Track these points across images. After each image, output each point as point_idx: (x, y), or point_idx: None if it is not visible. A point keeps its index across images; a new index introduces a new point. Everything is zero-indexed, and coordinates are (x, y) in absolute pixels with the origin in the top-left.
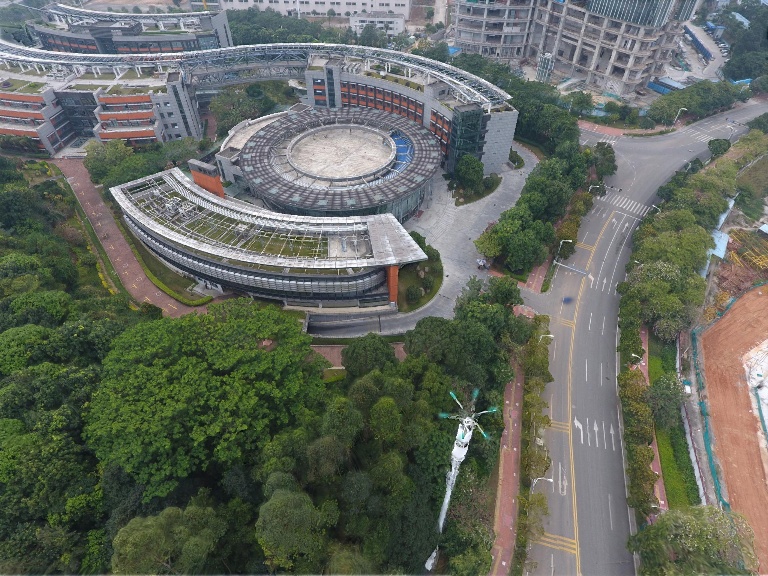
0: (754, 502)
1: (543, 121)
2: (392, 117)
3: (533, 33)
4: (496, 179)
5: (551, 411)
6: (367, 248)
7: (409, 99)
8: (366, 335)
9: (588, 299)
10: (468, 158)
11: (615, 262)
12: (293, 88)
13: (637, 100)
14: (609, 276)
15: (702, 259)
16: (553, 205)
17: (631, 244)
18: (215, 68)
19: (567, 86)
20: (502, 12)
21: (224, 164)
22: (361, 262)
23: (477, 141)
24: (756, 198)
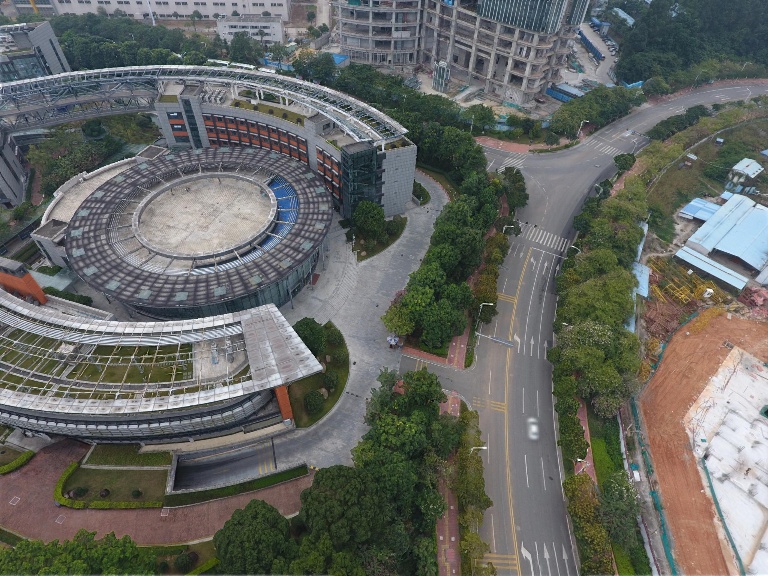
0: None
1: (445, 147)
2: (270, 158)
3: (424, 37)
4: (401, 222)
5: (493, 541)
6: (246, 354)
7: (289, 134)
8: (247, 506)
9: (517, 369)
10: (365, 206)
11: (540, 315)
12: (151, 115)
13: (538, 109)
14: (536, 334)
15: (630, 308)
16: (467, 256)
17: (554, 289)
18: (30, 105)
19: (466, 96)
20: (389, 15)
21: (45, 245)
22: (234, 389)
23: (374, 183)
24: (666, 217)
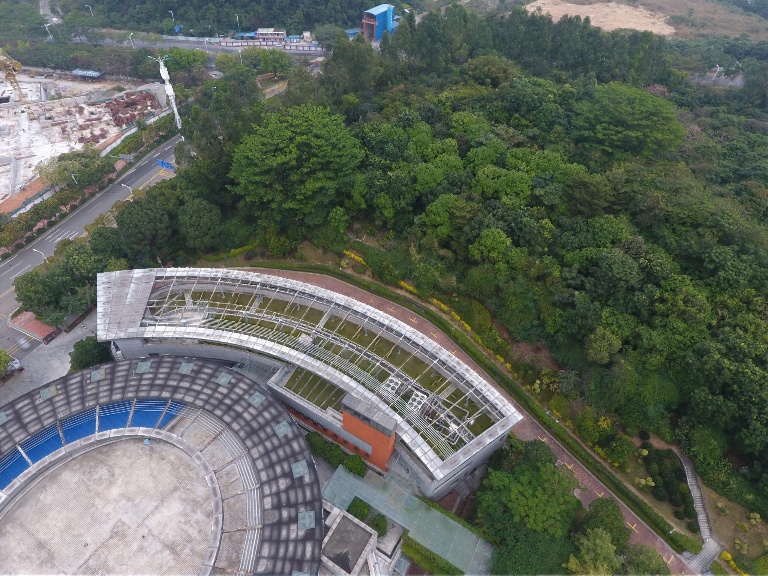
0: (3, 210)
1: None
2: None
3: None
4: None
5: None
6: None
7: None
8: None
9: None
10: None
11: None
12: None
13: None
14: None
15: None
16: None
17: None
18: None
19: None
20: None
21: None
22: (172, 272)
23: None
24: None
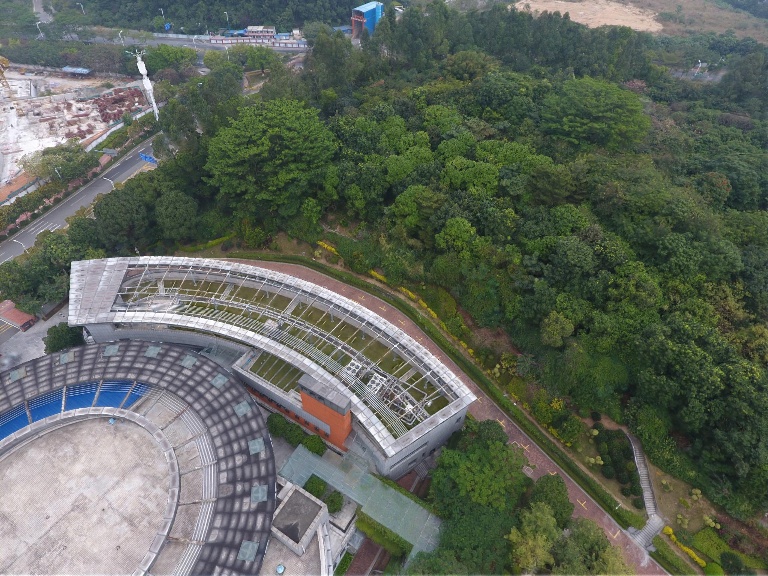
0: None
1: None
2: None
3: None
4: None
5: None
6: None
7: None
8: (172, 222)
9: None
10: None
11: None
12: None
13: None
14: None
15: None
16: None
17: None
18: None
19: None
20: None
21: None
22: (145, 260)
23: None
24: None
